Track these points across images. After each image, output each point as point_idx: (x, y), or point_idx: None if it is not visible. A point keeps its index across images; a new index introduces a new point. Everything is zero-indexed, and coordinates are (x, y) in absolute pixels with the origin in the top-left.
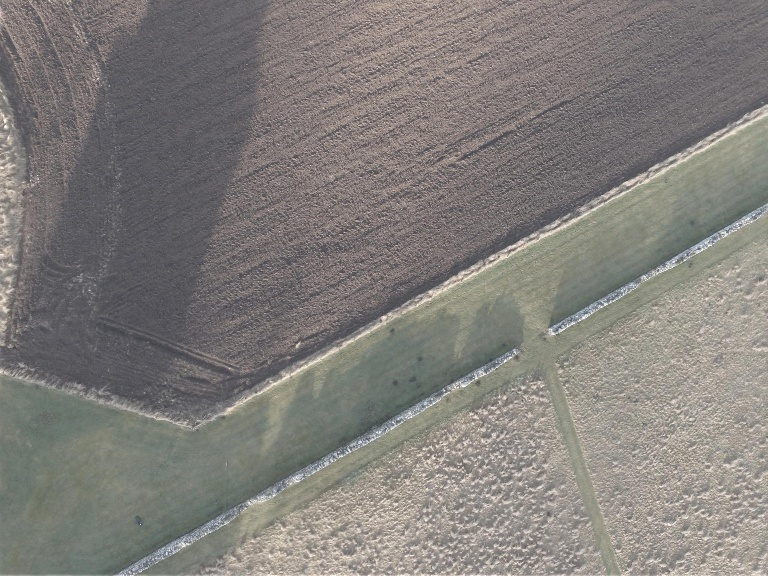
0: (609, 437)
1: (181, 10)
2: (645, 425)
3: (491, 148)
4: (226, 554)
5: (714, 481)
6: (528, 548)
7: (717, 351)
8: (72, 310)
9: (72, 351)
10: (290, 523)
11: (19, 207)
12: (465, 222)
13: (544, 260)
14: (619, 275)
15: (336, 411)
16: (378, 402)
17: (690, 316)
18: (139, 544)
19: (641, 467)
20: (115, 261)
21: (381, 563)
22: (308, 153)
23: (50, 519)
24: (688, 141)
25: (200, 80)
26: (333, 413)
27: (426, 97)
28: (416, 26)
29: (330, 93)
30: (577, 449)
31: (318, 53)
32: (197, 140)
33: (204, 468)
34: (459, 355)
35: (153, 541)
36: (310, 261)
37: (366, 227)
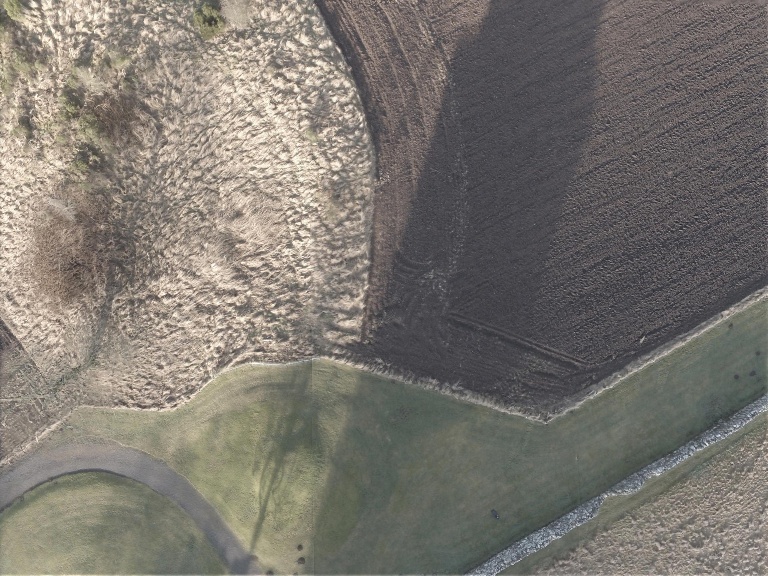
0: None
1: (521, 9)
2: None
3: None
4: (578, 547)
5: None
6: None
7: None
8: (424, 306)
9: (424, 346)
10: (640, 516)
11: (371, 204)
12: None
13: None
14: None
15: (681, 405)
16: (721, 396)
17: None
18: (496, 537)
19: None
20: (463, 257)
21: (726, 556)
22: (647, 150)
23: (411, 513)
24: None
25: (541, 78)
26: (678, 407)
27: (760, 94)
28: (750, 24)
29: (668, 90)
30: None
31: (655, 51)
32: (539, 137)
33: (555, 462)
34: None
35: (510, 534)
36: (652, 257)
37: (705, 223)
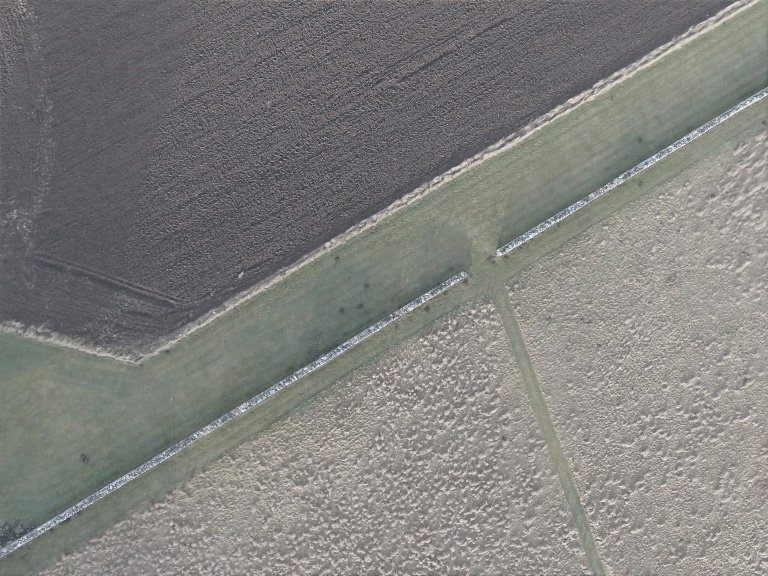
0: (563, 359)
1: None
2: (599, 346)
3: (431, 69)
4: (175, 489)
5: (672, 401)
6: (484, 473)
7: (670, 269)
8: (7, 247)
9: (9, 289)
10: (239, 456)
11: None
12: (407, 145)
13: (490, 182)
14: (567, 194)
15: (282, 341)
16: (325, 330)
17: (642, 235)
18: (85, 482)
19: (597, 388)
20: (50, 196)
21: (334, 493)
22: (244, 80)
23: None
24: (633, 56)
25: (130, 9)
26: (279, 343)
27: (363, 19)
28: None
29: (264, 17)
30: (531, 372)
31: None
32: (129, 70)
33: (149, 403)
34: (406, 280)
35: (99, 478)
36: (250, 189)
37: (306, 153)
